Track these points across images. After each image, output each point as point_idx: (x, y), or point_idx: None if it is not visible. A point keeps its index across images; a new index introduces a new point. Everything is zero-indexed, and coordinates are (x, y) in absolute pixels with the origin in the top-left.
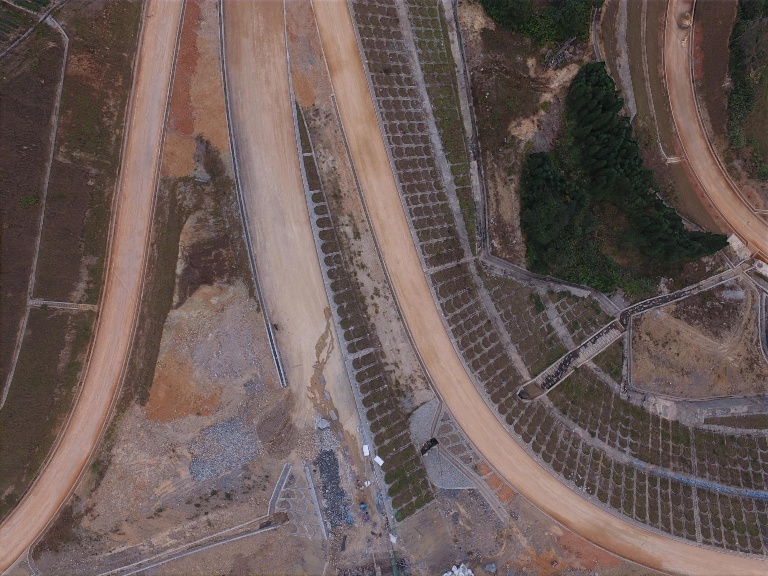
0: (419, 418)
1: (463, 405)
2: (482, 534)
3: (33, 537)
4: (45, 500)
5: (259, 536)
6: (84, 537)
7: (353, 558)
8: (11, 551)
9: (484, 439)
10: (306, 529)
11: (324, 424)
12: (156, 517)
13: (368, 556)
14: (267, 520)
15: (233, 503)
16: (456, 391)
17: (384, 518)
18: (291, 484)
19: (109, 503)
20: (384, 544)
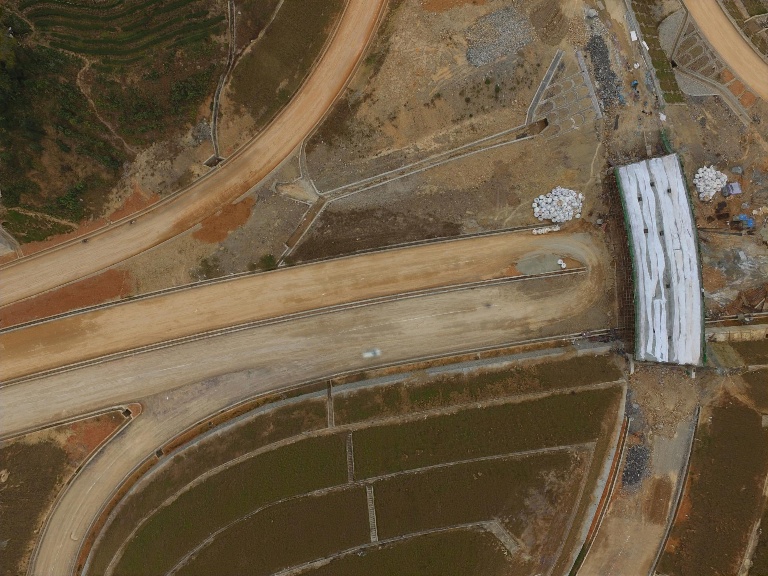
0: (665, 30)
1: (706, 17)
2: (728, 138)
3: (305, 132)
4: (317, 97)
5: (518, 144)
6: (356, 132)
7: (626, 136)
8: (282, 147)
9: (726, 49)
10: (573, 121)
11: (594, 12)
12: (432, 106)
13: (639, 135)
14: (523, 132)
15: (496, 107)
16: (699, 4)
17: (653, 97)
18: (558, 77)
19: (388, 89)
20: (654, 122)
